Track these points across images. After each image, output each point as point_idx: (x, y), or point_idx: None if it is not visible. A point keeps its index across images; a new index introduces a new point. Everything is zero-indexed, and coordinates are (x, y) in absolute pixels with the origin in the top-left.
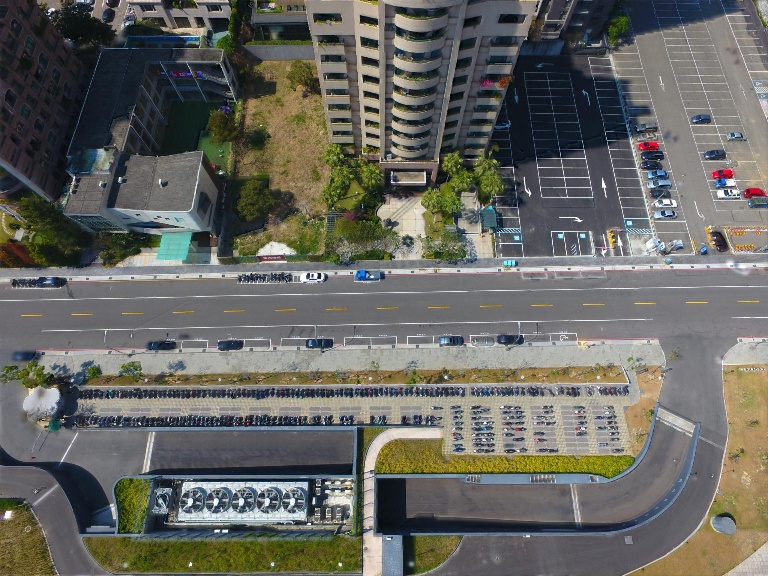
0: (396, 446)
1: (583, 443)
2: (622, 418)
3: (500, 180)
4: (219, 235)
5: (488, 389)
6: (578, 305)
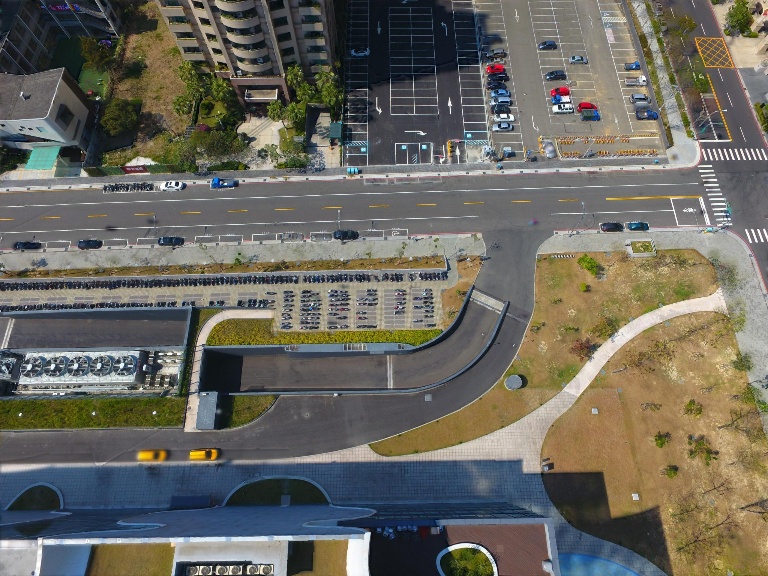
0: (228, 324)
1: (400, 320)
2: (439, 299)
3: (354, 100)
4: (87, 149)
5: (320, 277)
6: (412, 205)
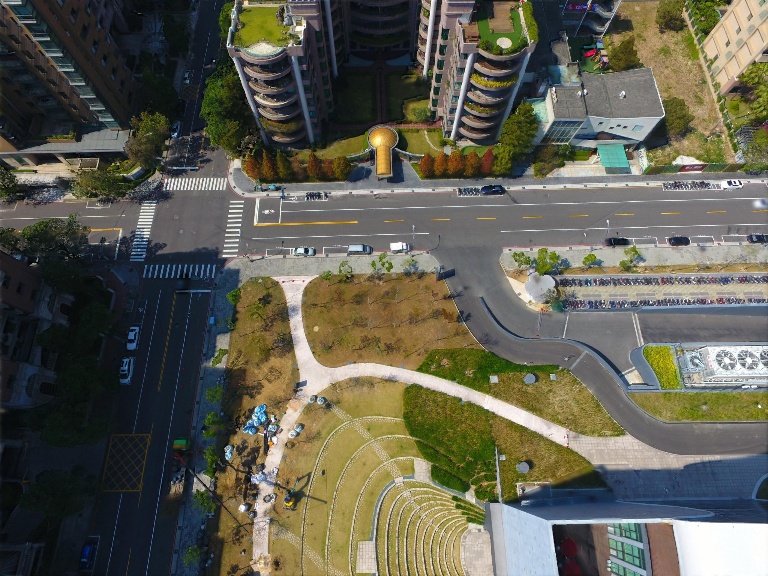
0: None
1: None
2: None
3: None
4: (642, 148)
5: None
6: None
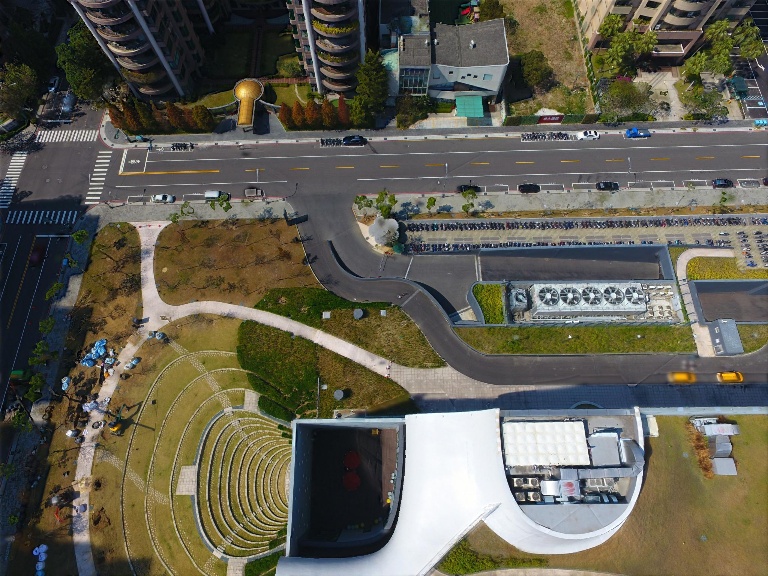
0: (699, 261)
1: None
2: None
3: (735, 58)
4: None
5: (765, 219)
6: None
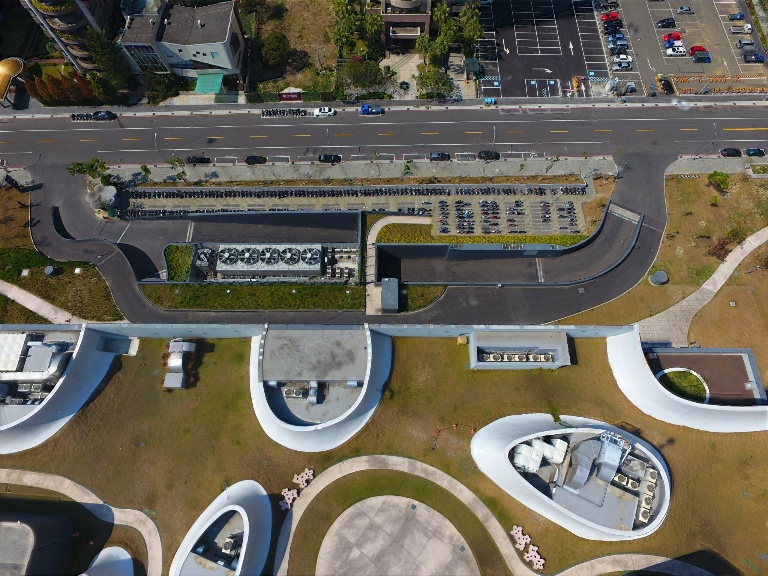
0: (393, 227)
1: (547, 227)
2: (580, 210)
3: (483, 42)
4: (246, 78)
5: (470, 190)
6: (546, 132)
